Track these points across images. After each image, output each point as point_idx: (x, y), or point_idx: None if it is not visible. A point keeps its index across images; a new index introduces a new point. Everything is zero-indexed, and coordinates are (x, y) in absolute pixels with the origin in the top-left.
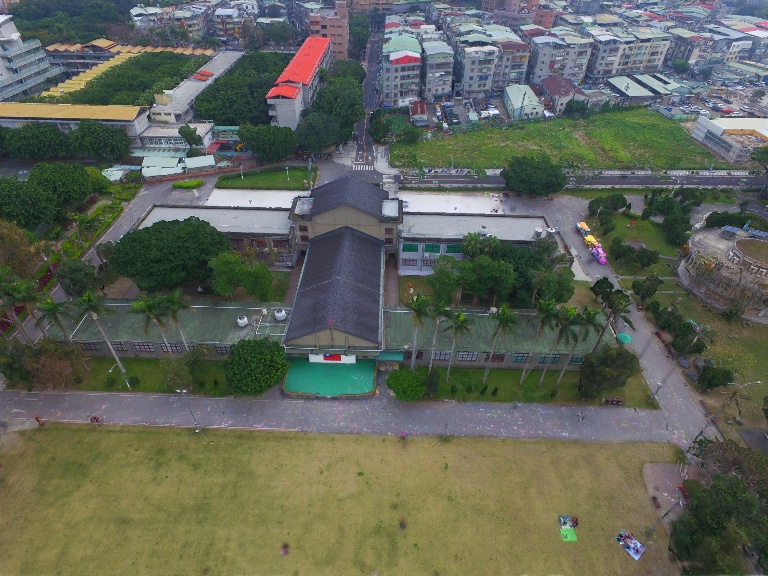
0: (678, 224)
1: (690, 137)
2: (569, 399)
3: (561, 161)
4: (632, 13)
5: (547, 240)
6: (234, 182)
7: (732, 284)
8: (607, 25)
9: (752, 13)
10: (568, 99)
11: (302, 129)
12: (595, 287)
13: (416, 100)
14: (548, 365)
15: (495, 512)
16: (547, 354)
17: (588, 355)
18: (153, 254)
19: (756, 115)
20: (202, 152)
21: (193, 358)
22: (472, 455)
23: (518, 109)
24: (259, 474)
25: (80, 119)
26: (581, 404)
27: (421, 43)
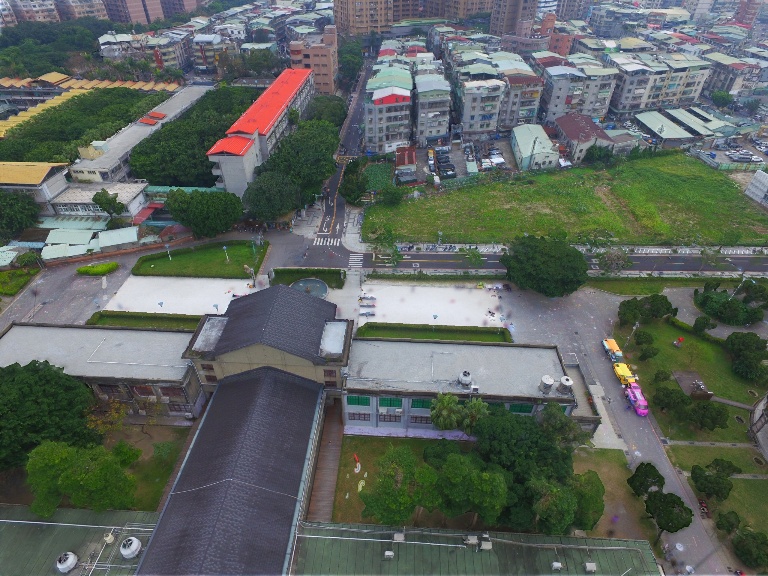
0: (750, 351)
1: (744, 195)
2: None
3: (580, 236)
4: (660, 35)
5: (560, 415)
6: (158, 264)
7: None
8: (633, 50)
9: None
10: (589, 145)
11: (250, 194)
12: (635, 482)
13: (406, 144)
14: None
15: None
16: None
17: None
18: None
19: None
20: (127, 221)
21: None
22: None
23: (527, 158)
24: None
25: None
26: None
27: (413, 76)
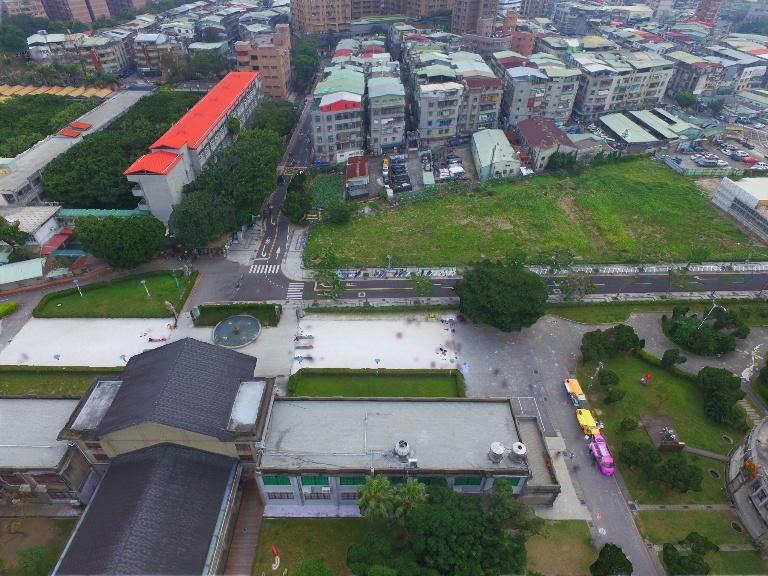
0: (723, 391)
1: (710, 204)
2: None
3: (541, 257)
4: (624, 32)
5: (508, 502)
6: (66, 303)
7: None
8: (596, 49)
9: (757, 30)
10: (551, 152)
11: (176, 217)
12: (599, 572)
13: (359, 153)
14: None
15: None
16: None
17: None
18: None
19: None
20: (34, 252)
21: None
22: None
23: (487, 167)
24: None
25: None
26: None
27: (366, 80)
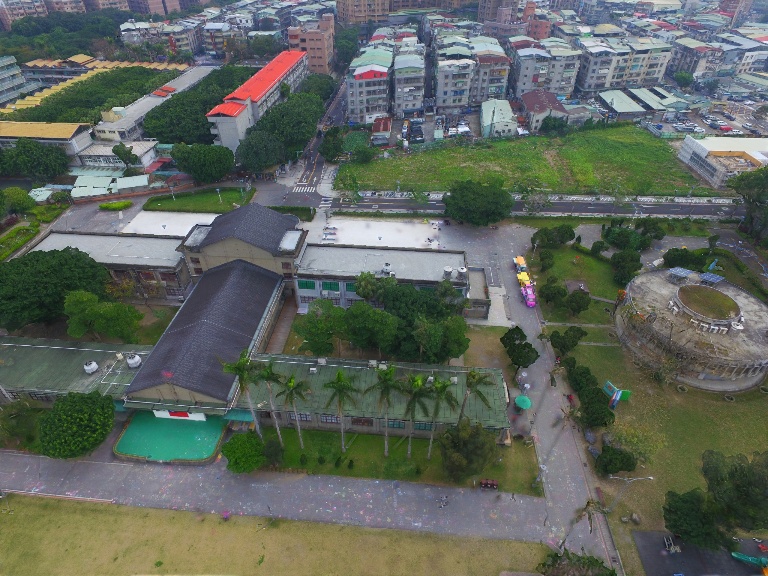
0: (625, 262)
1: (675, 158)
2: (438, 477)
3: (516, 185)
4: (641, 22)
5: (445, 283)
6: (164, 204)
7: (664, 341)
8: (606, 35)
9: None
10: (544, 116)
11: (241, 148)
12: (504, 338)
13: (384, 116)
14: (425, 432)
15: None
16: (418, 421)
17: (447, 431)
18: (5, 290)
19: (759, 133)
20: (140, 171)
21: (13, 411)
22: (297, 546)
23: (488, 126)
24: (45, 557)
25: (17, 137)
26: (450, 485)
27: (394, 57)
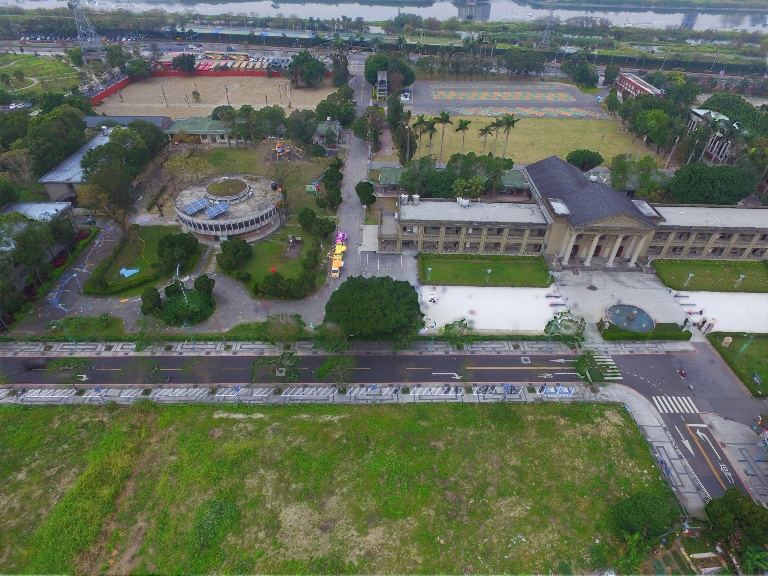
0: None
1: None
2: None
3: None
4: None
5: (419, 172)
6: None
7: None
8: None
9: None
10: None
11: None
12: None
13: None
14: None
15: (457, 148)
16: None
17: None
18: (701, 163)
19: None
20: None
21: None
22: None
23: None
24: None
25: None
26: None
27: None
